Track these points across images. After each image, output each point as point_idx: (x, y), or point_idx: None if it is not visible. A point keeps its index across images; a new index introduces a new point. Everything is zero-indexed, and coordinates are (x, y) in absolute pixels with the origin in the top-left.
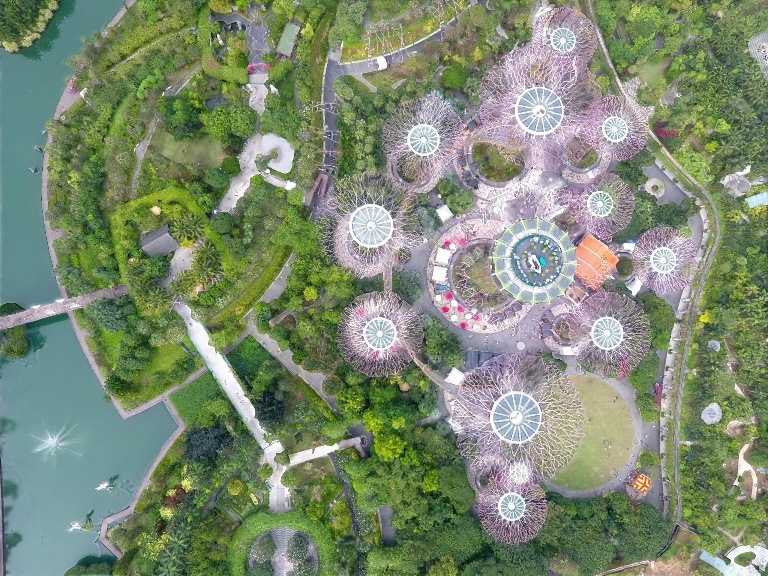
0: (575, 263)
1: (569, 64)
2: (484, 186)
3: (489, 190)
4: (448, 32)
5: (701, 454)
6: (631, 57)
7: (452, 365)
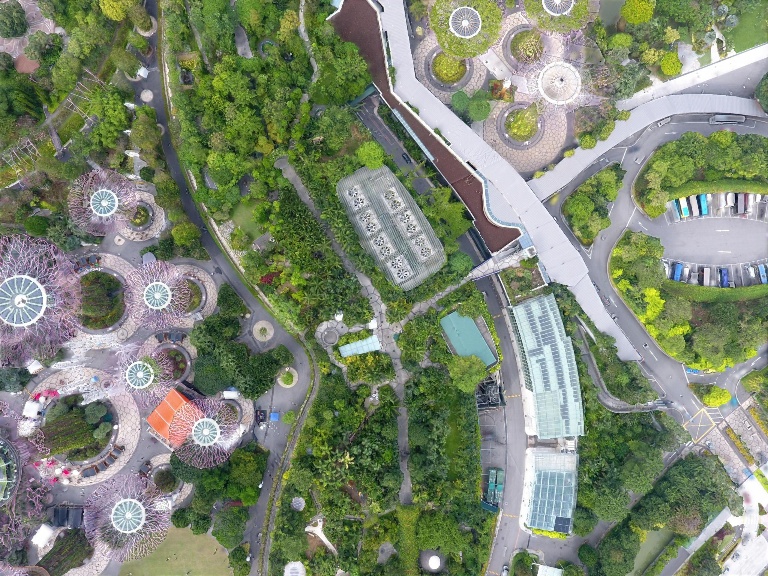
0: (4, 480)
1: (48, 252)
2: (82, 334)
3: (87, 338)
4: (25, 180)
5: None
6: (216, 203)
7: (31, 525)
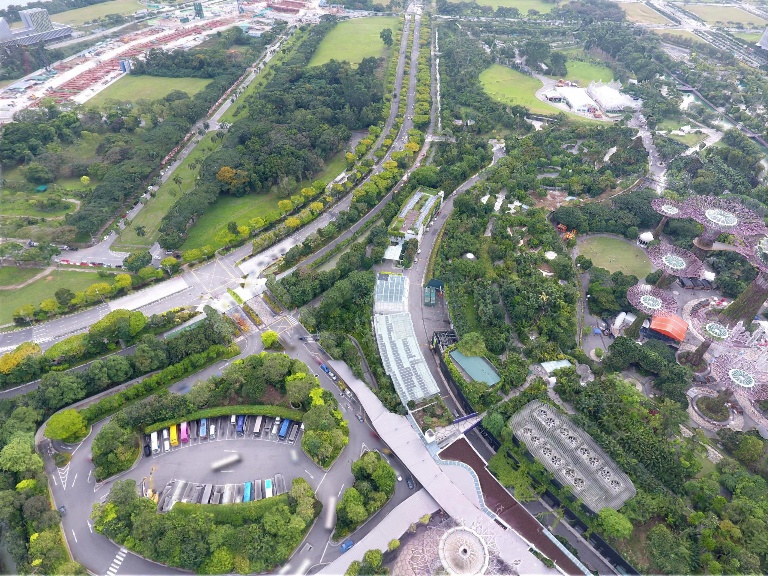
0: (766, 252)
1: None
2: None
3: None
4: None
5: None
6: None
7: None
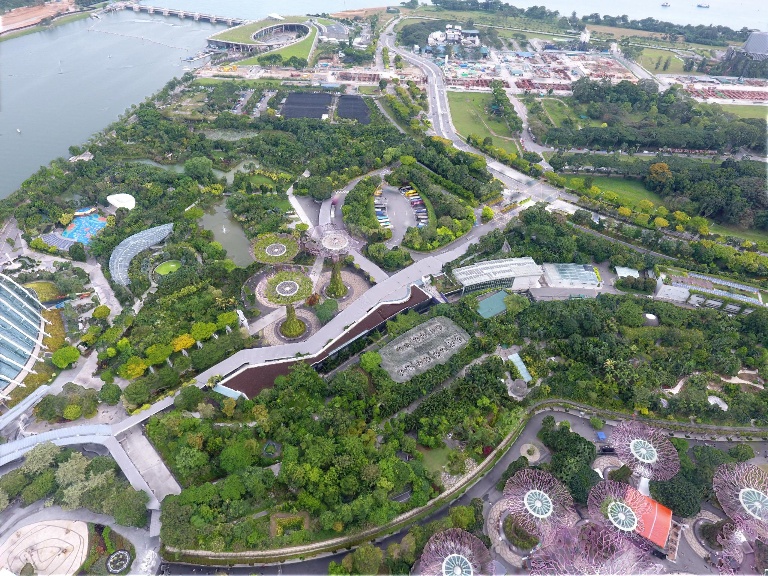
0: None
1: (541, 572)
2: None
3: None
4: None
5: (761, 411)
6: None
7: None
